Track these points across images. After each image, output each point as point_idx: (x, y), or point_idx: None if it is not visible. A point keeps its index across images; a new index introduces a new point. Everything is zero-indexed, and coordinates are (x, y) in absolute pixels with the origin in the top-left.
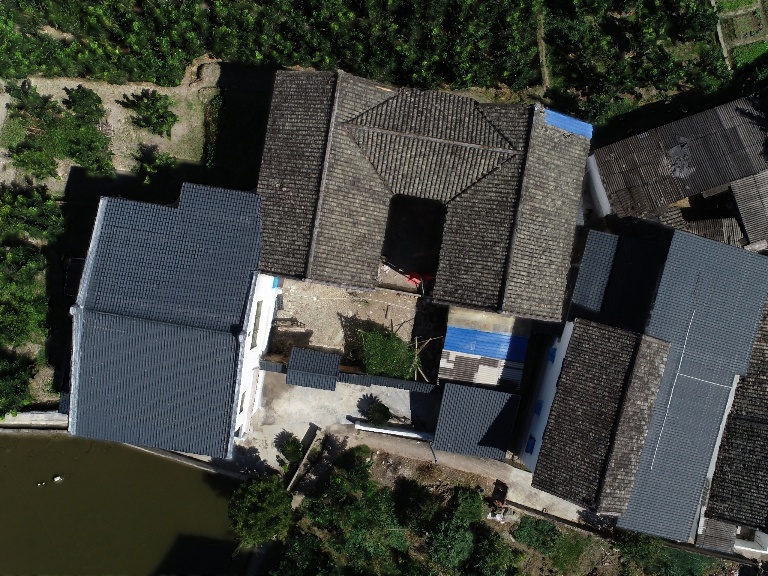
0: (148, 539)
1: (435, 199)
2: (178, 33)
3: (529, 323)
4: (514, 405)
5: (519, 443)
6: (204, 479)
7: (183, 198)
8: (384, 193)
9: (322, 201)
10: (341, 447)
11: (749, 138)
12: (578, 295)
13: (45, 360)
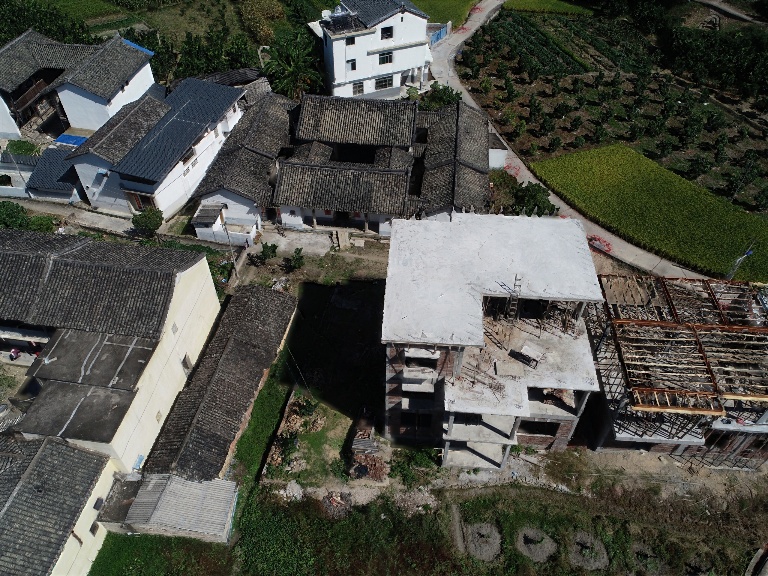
0: None
1: (62, 68)
2: None
3: None
4: None
5: None
6: None
7: None
8: None
9: None
10: None
11: None
12: None
13: None
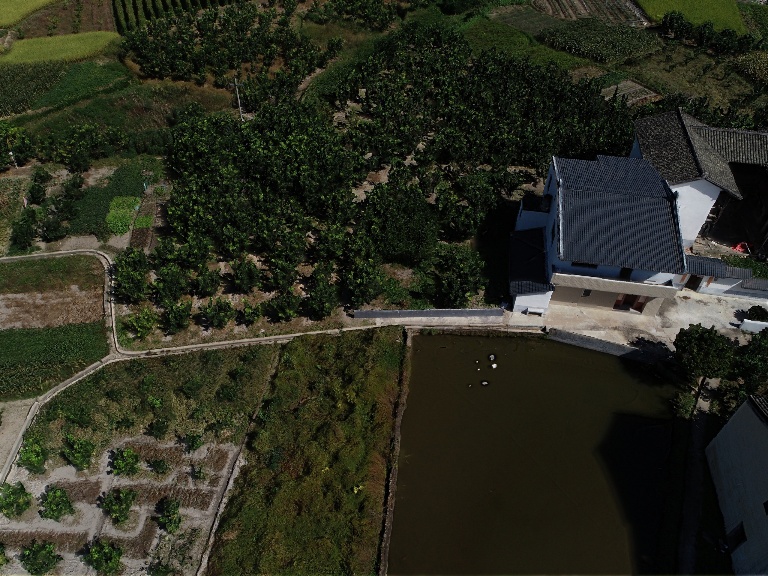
0: (582, 421)
1: (755, 164)
2: None
3: None
4: None
5: None
6: (622, 370)
7: (601, 159)
8: (723, 159)
9: (695, 149)
10: (735, 344)
11: None
12: None
13: None
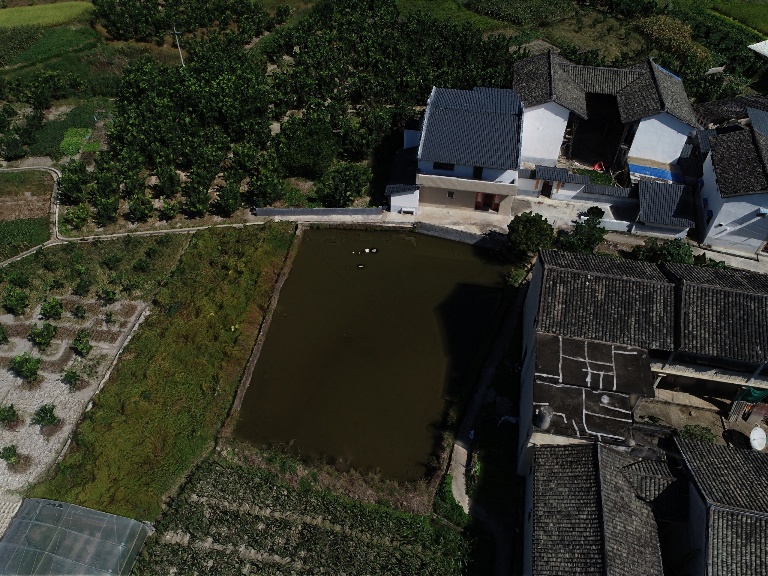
0: (432, 290)
1: (608, 94)
2: (451, 78)
3: (679, 170)
4: (688, 191)
5: (700, 237)
6: (474, 255)
7: (475, 89)
8: (581, 90)
9: (553, 79)
10: (572, 236)
11: (766, 102)
12: (704, 150)
13: (364, 196)
